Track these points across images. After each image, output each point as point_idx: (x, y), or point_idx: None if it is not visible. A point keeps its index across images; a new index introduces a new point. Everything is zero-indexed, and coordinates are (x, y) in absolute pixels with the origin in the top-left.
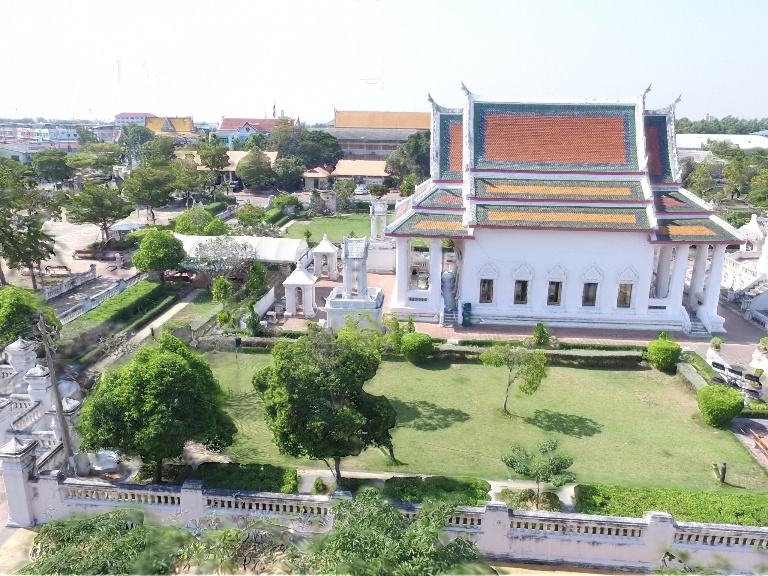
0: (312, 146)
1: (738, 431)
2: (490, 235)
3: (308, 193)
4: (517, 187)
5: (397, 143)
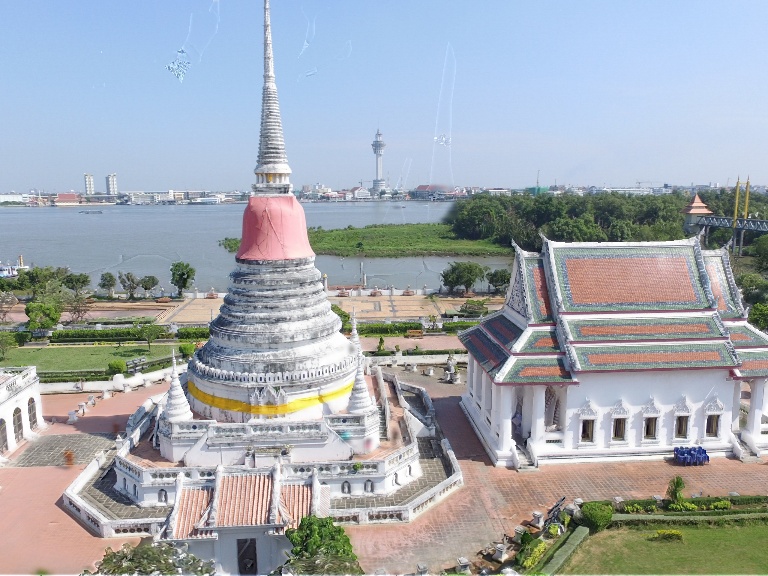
0: None
1: None
2: None
3: None
4: None
5: None
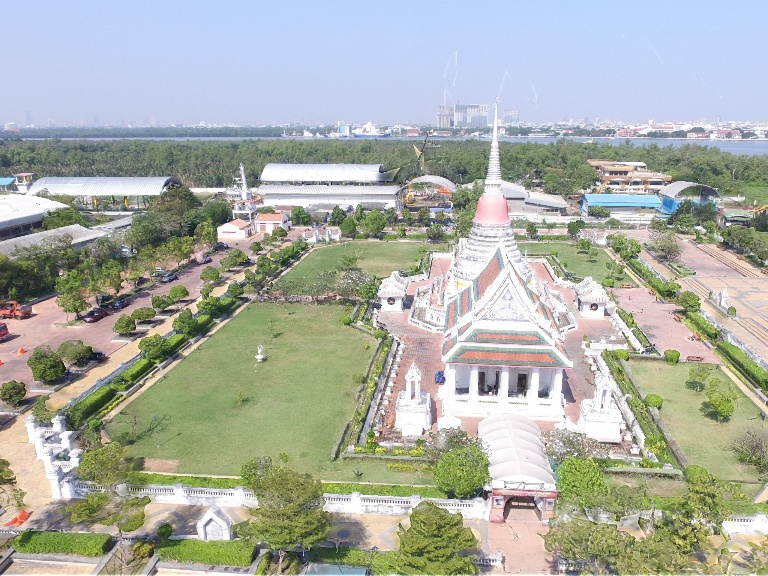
0: None
1: None
2: None
3: None
4: None
5: None
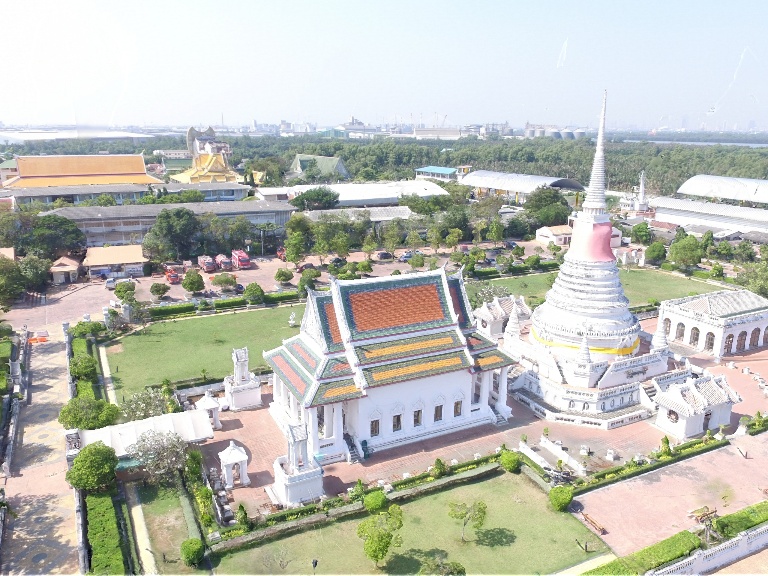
0: (50, 234)
1: (572, 511)
2: (375, 390)
3: (67, 293)
4: (384, 349)
5: (139, 218)
